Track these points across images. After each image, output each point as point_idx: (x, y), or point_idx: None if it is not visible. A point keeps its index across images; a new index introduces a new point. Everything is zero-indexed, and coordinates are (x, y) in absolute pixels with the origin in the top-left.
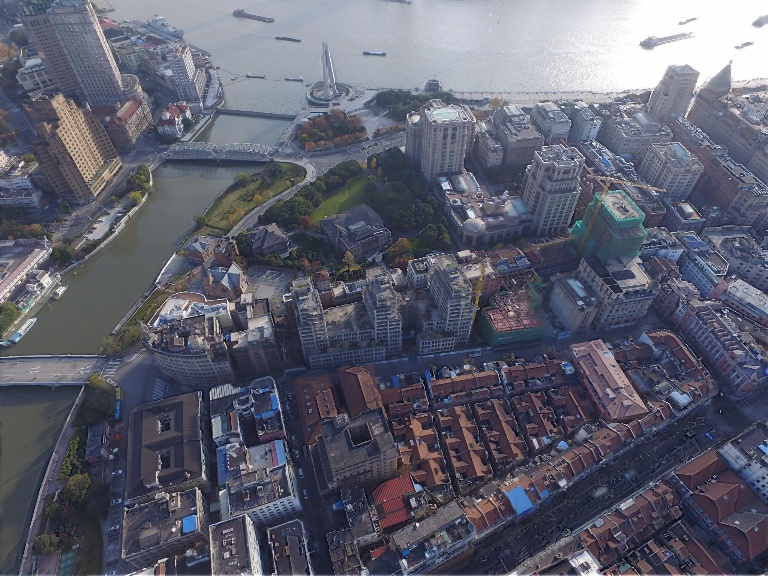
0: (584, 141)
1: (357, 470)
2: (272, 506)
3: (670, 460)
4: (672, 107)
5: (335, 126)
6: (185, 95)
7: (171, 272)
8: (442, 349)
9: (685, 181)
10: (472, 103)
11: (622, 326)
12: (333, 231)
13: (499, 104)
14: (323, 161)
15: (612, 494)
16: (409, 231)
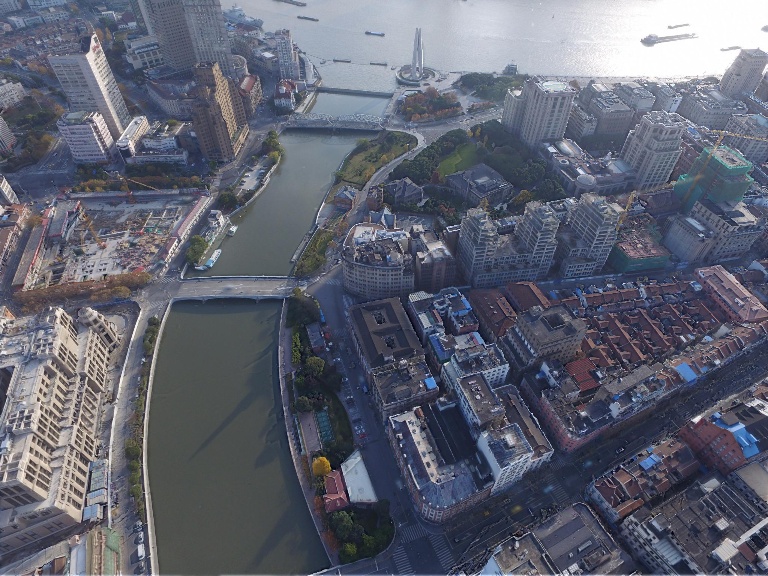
0: None
1: (554, 348)
2: (492, 373)
3: None
4: (743, 87)
5: (434, 101)
6: (287, 74)
7: (325, 216)
8: (583, 274)
9: (765, 146)
10: None
11: (729, 260)
12: (463, 184)
13: (577, 85)
14: (429, 131)
15: (750, 377)
16: (524, 187)
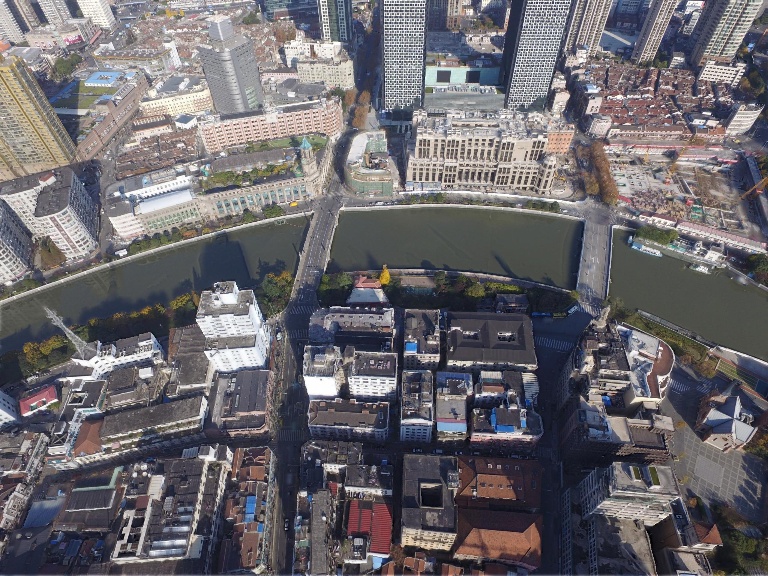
0: None
1: None
2: None
3: None
4: None
5: None
6: None
7: (742, 363)
8: None
9: None
10: None
11: None
12: None
13: None
14: None
15: None
16: None
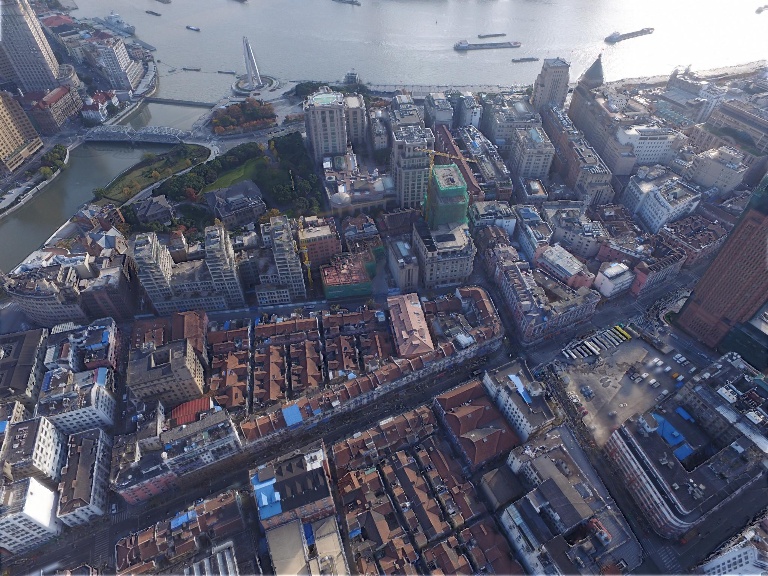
0: (463, 127)
1: (156, 388)
2: (76, 415)
3: None
4: (550, 97)
5: (246, 113)
6: (118, 84)
7: (61, 236)
8: (279, 301)
9: (540, 162)
10: (384, 95)
11: (450, 285)
12: (213, 202)
13: None
14: (229, 144)
15: None
16: (287, 204)
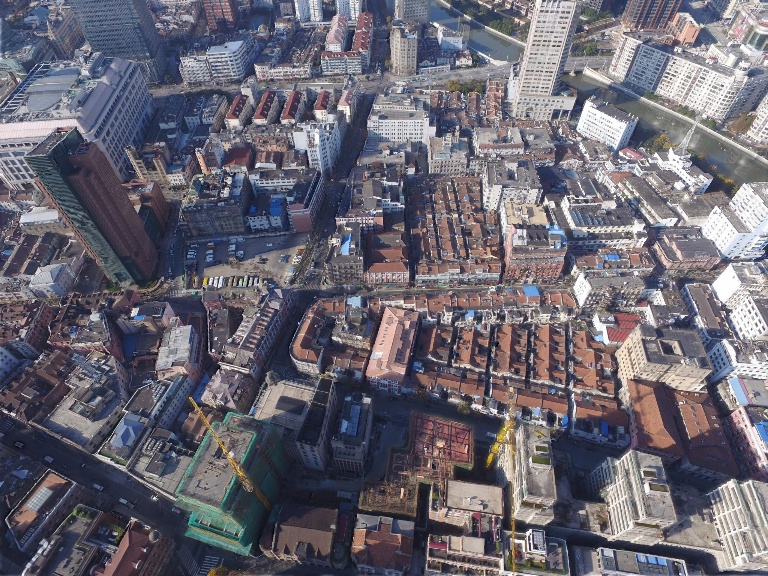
0: None
1: None
2: None
3: (386, 295)
4: None
5: None
6: None
7: None
8: None
9: None
10: None
11: None
12: None
13: None
14: None
15: None
16: None
